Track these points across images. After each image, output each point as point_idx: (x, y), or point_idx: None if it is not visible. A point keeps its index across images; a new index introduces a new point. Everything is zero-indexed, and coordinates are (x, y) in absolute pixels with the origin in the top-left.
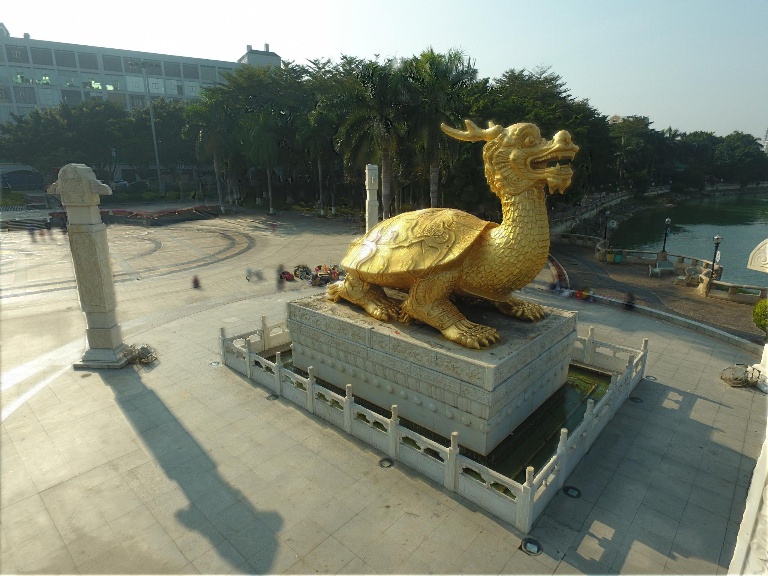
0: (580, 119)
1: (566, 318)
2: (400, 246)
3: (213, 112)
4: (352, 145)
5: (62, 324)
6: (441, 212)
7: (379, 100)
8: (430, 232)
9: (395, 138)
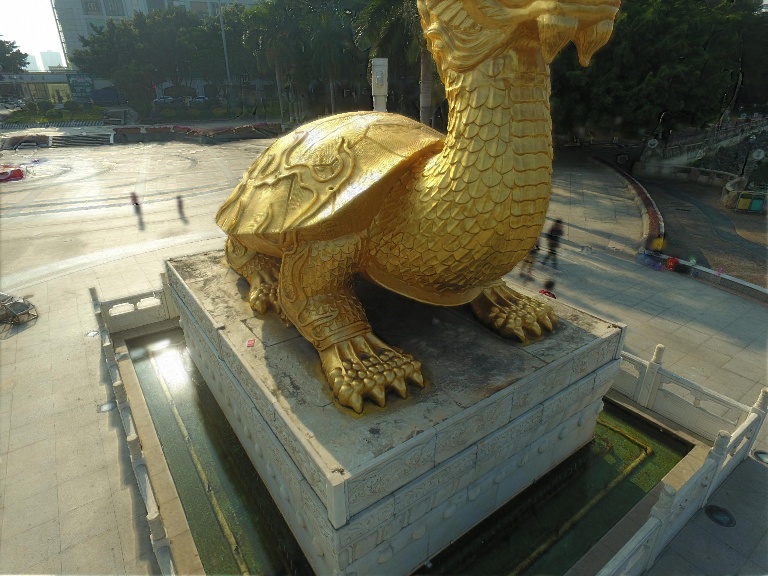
0: (735, 2)
1: (594, 340)
2: (264, 183)
3: (273, 14)
4: (379, 37)
5: (11, 255)
6: (354, 118)
7: None
8: (312, 158)
9: None
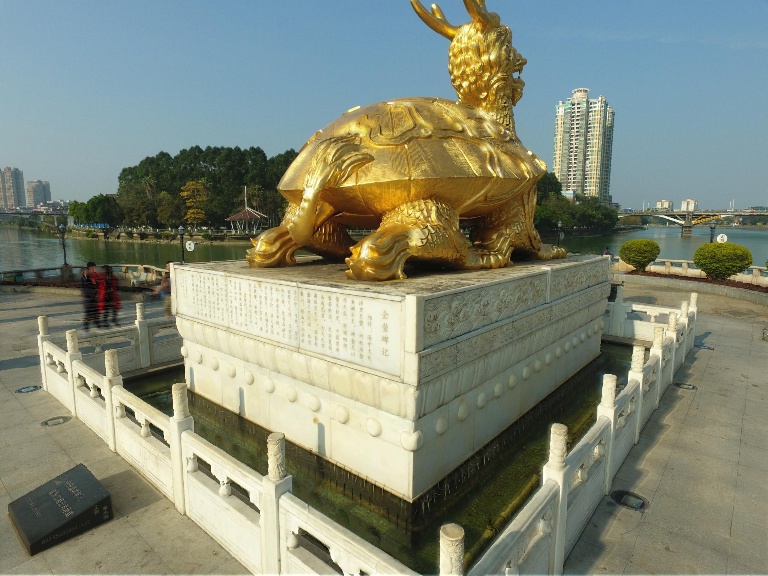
0: None
1: None
2: (510, 139)
3: None
4: None
5: None
6: None
7: None
8: None
9: None
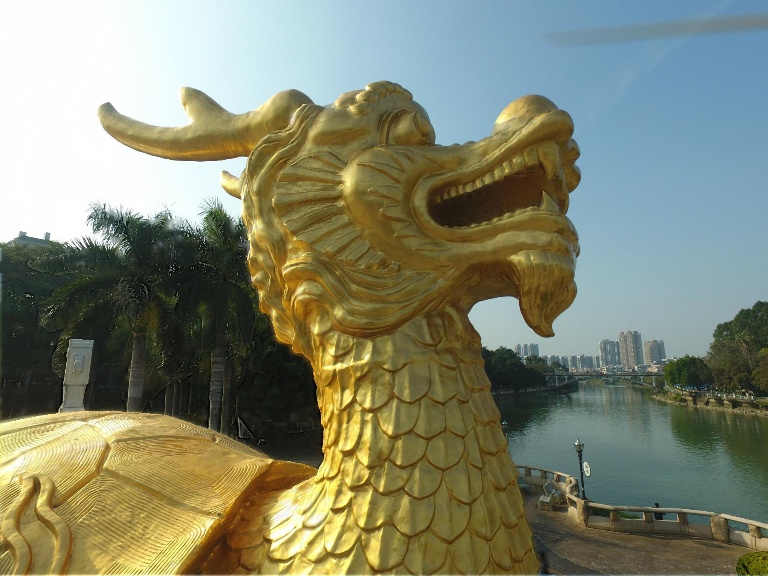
0: None
1: None
2: None
3: None
4: (78, 318)
5: None
6: (67, 427)
7: (137, 259)
8: None
9: (158, 313)
